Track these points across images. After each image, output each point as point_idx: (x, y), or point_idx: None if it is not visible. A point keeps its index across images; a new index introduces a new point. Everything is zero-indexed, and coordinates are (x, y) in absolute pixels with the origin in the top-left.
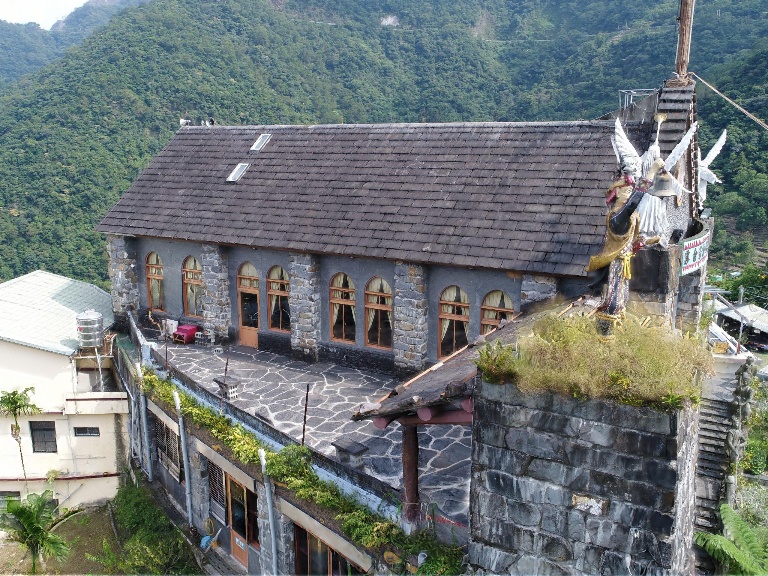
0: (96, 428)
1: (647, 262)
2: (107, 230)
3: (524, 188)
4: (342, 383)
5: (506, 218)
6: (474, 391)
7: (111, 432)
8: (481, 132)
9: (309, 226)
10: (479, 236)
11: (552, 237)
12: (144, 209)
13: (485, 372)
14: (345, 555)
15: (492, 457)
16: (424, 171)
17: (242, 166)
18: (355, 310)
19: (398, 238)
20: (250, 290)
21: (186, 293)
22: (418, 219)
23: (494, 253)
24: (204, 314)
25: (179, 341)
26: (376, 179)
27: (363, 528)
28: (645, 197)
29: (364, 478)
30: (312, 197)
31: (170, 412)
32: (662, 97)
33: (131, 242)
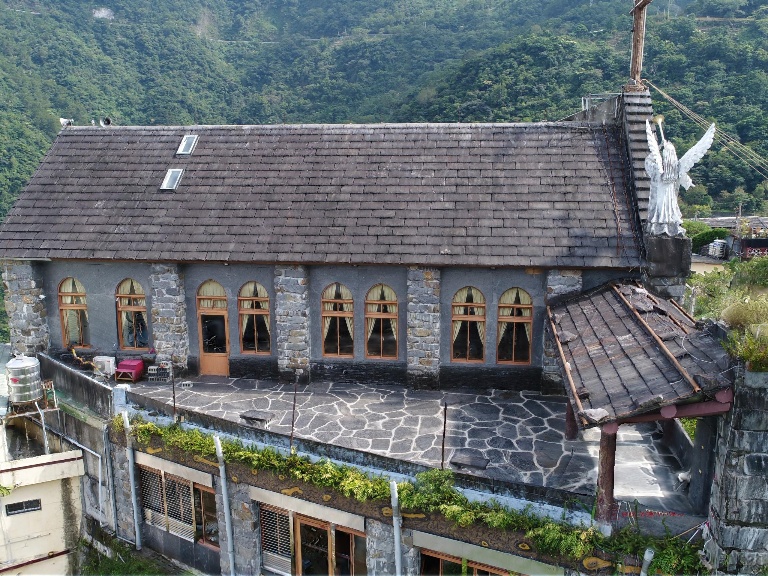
0: (35, 500)
1: (672, 250)
2: (6, 255)
3: (520, 187)
4: (361, 400)
5: (515, 216)
6: (736, 381)
7: (57, 502)
8: (449, 133)
9: (295, 235)
10: (495, 235)
11: (569, 232)
12: (53, 227)
13: (758, 361)
14: (522, 573)
15: (754, 441)
16: (405, 173)
17: (174, 172)
18: (352, 321)
19: (408, 242)
20: (215, 312)
21: (120, 323)
22: (421, 222)
23: (518, 251)
24: (156, 345)
25: (124, 380)
26: (353, 182)
27: (568, 540)
28: (662, 191)
29: (535, 490)
30: (284, 204)
31: (192, 462)
32: (626, 101)
33: (37, 268)
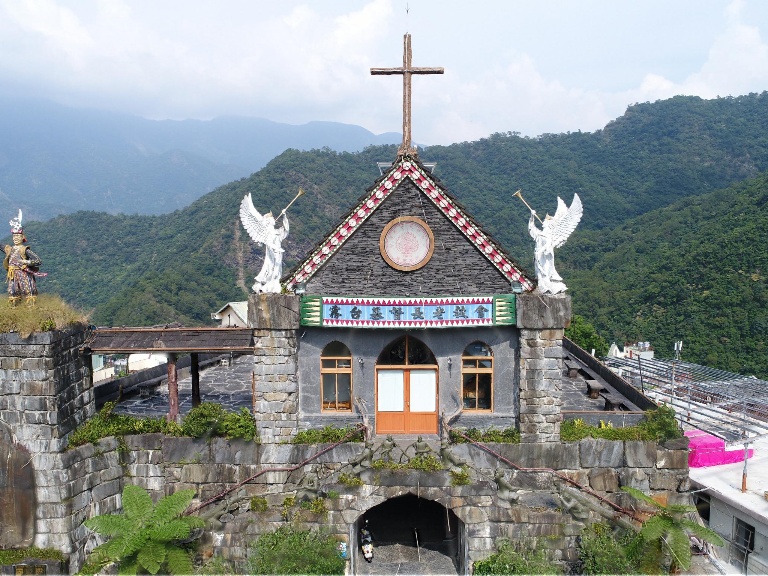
0: None
1: None
2: None
3: None
4: None
5: None
6: None
7: None
8: None
9: None
10: None
11: None
12: None
13: None
14: None
15: None
16: None
17: None
18: None
19: None
20: None
21: None
22: None
23: None
24: None
25: None
26: None
27: None
28: None
29: None
30: None
31: None
32: None
33: None
